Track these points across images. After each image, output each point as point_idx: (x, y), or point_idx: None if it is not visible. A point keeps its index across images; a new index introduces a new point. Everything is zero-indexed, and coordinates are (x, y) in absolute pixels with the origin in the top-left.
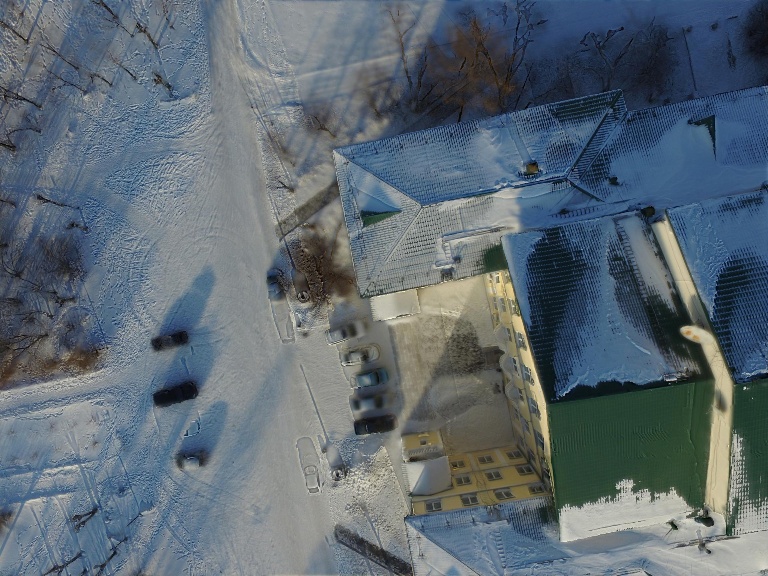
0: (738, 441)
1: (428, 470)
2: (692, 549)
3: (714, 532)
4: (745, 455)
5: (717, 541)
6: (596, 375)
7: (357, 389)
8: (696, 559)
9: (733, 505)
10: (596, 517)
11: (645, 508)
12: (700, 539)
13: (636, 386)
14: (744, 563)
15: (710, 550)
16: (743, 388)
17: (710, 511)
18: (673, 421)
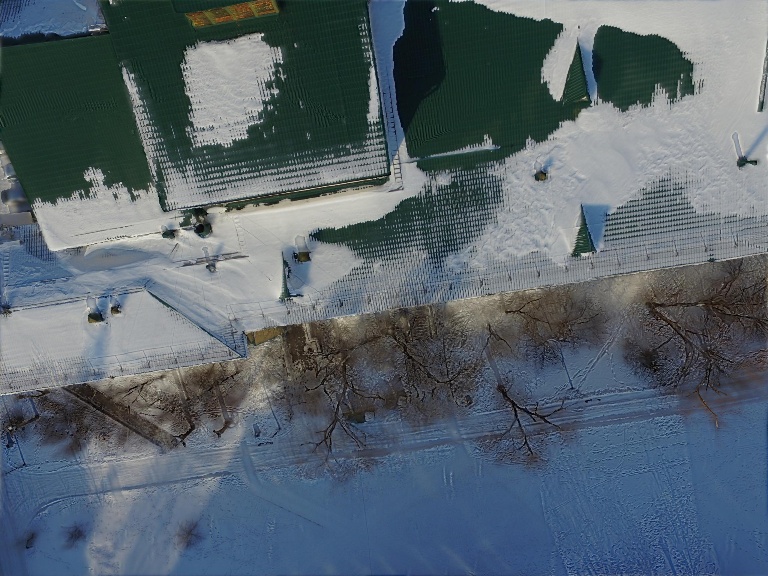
0: (130, 78)
1: (1, 222)
2: (201, 270)
3: (221, 250)
4: (145, 98)
5: (225, 260)
6: (22, 28)
7: (14, 184)
8: (207, 282)
9: (155, 168)
10: (77, 218)
11: (128, 209)
12: (206, 257)
13: (58, 36)
14: (258, 288)
15: (221, 272)
16: (109, 2)
17: (212, 224)
18: (126, 95)
